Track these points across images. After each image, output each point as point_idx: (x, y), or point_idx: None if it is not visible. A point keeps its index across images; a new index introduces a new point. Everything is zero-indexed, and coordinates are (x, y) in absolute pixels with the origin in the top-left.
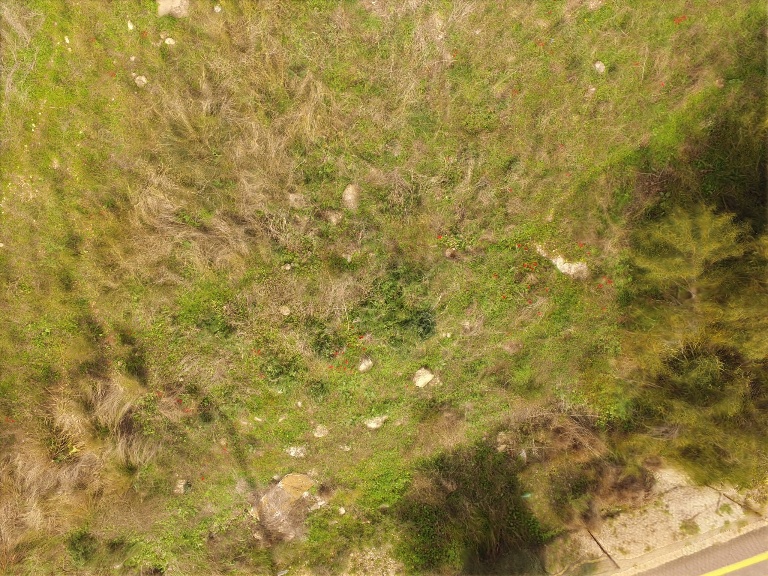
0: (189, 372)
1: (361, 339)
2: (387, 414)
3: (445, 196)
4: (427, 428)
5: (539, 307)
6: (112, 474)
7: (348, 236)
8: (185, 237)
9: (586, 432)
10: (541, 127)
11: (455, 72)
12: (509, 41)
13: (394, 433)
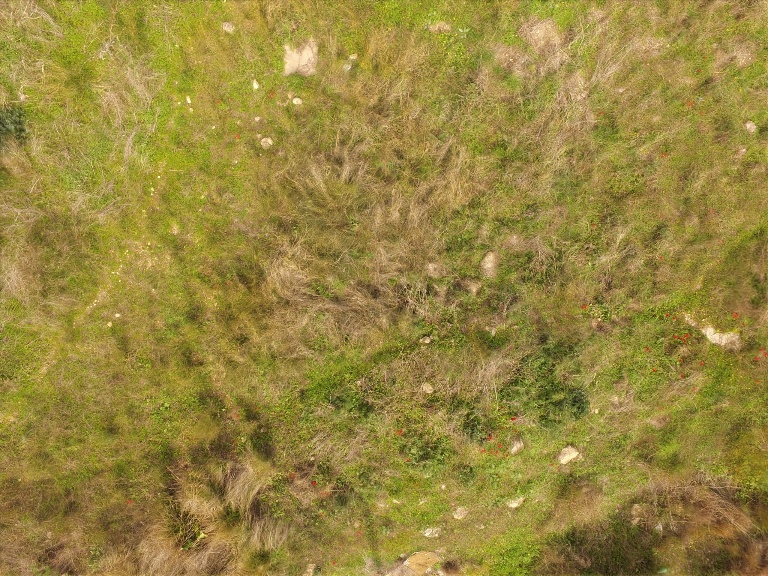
0: (320, 451)
1: (514, 421)
2: (530, 494)
3: (588, 263)
4: (564, 504)
5: (693, 382)
6: (248, 565)
7: (489, 307)
8: (320, 310)
9: (730, 506)
10: (691, 191)
11: (599, 133)
12: (658, 101)
13: (530, 510)
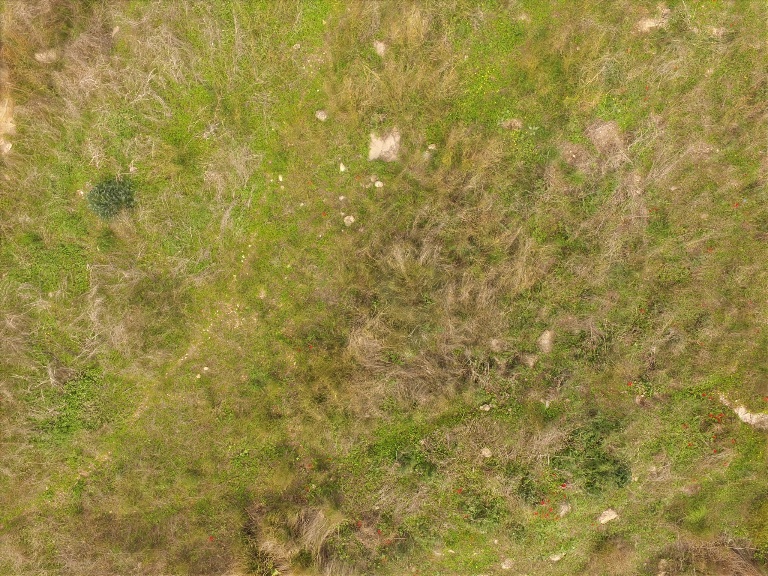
0: (385, 501)
1: (564, 488)
2: (571, 549)
3: (634, 343)
4: (600, 558)
5: (725, 458)
6: None
7: (544, 380)
8: (392, 376)
9: (749, 567)
10: (731, 284)
11: (651, 227)
12: (706, 202)
13: (569, 562)
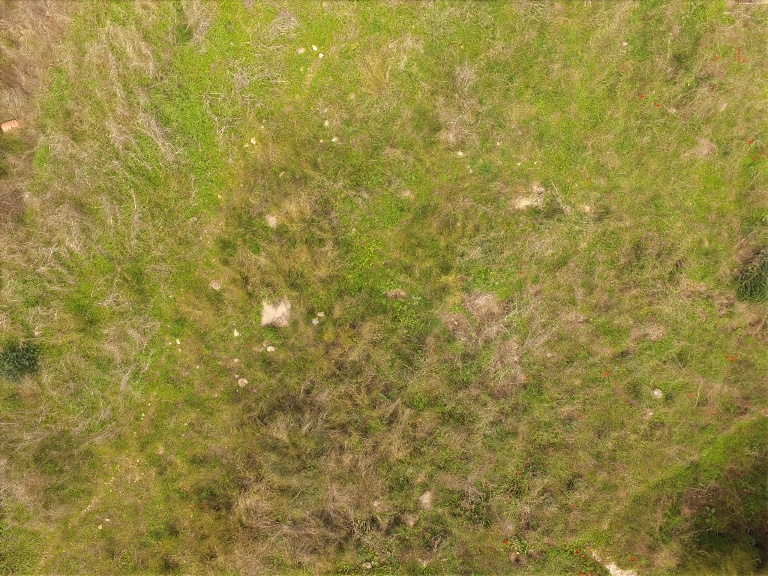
0: None
1: None
2: None
3: (512, 502)
4: None
5: None
6: None
7: (424, 539)
8: (278, 536)
9: None
10: (602, 448)
11: (527, 393)
12: (578, 371)
13: None
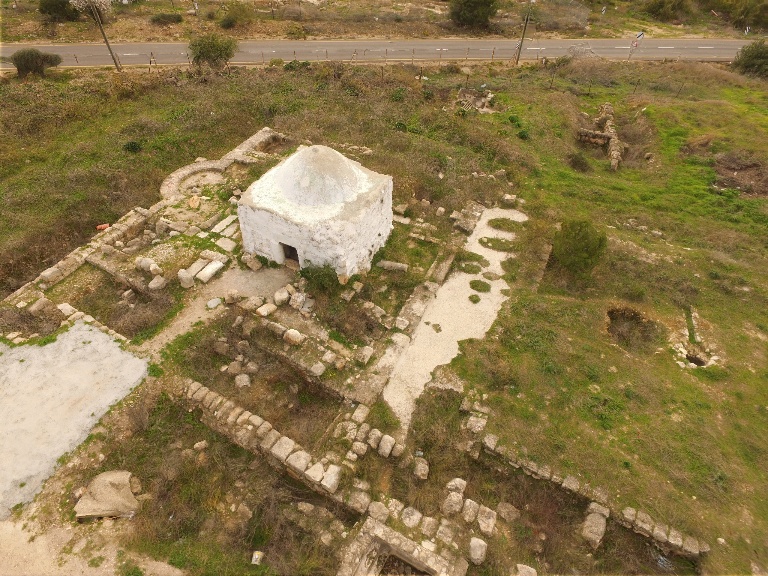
0: None
1: (17, 86)
2: None
3: None
4: None
5: None
6: None
7: (5, 109)
8: None
9: None
10: None
11: None
12: None
13: None
